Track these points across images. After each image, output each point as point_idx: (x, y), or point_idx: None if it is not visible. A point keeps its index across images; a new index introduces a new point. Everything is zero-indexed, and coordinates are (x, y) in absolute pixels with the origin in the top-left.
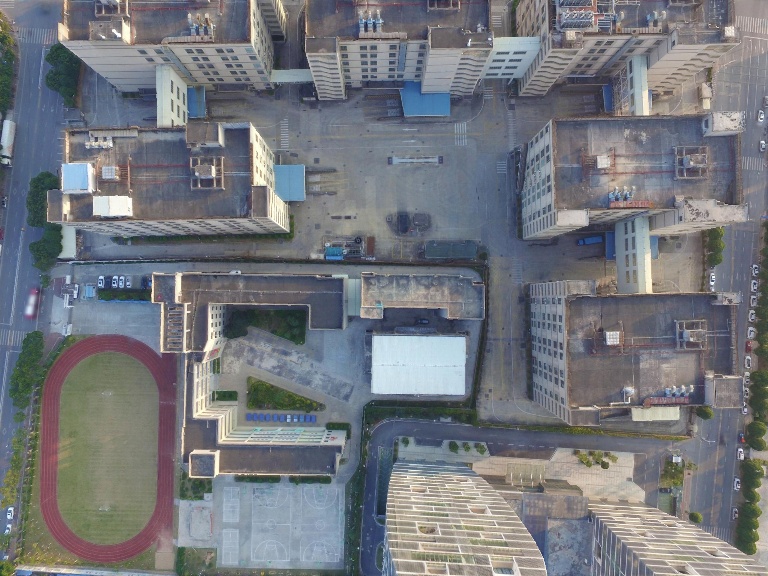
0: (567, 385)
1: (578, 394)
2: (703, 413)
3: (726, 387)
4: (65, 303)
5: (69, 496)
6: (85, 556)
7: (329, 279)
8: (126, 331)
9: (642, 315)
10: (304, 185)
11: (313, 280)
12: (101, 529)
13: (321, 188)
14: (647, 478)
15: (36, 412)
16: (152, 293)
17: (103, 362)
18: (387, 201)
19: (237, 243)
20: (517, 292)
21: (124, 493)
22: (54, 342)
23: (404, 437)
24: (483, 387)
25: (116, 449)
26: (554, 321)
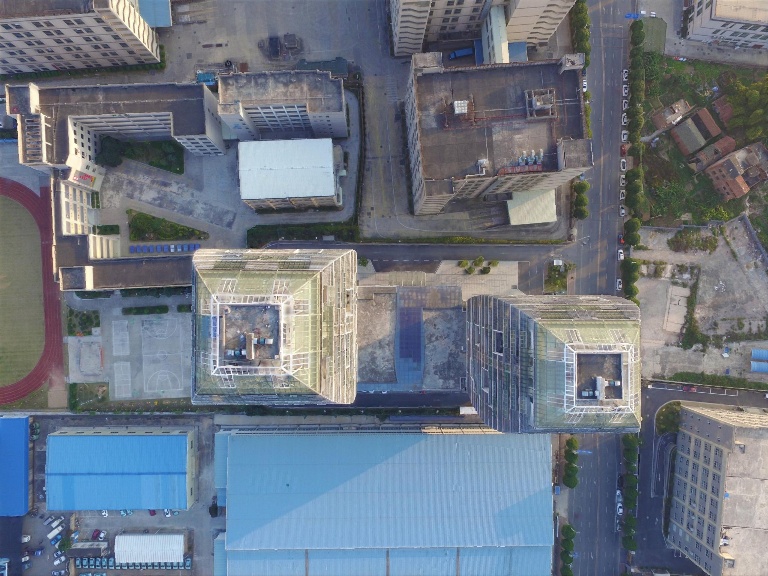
0: (421, 159)
1: (434, 169)
2: (578, 211)
3: (574, 148)
4: None
5: None
6: None
7: (189, 86)
8: (2, 172)
9: (492, 88)
10: (169, 10)
11: (173, 88)
12: None
13: (191, 18)
14: (532, 285)
15: None
16: (7, 105)
17: None
18: (258, 27)
19: (108, 77)
20: (393, 110)
21: (11, 334)
22: None
23: None
24: (365, 205)
25: None
26: None
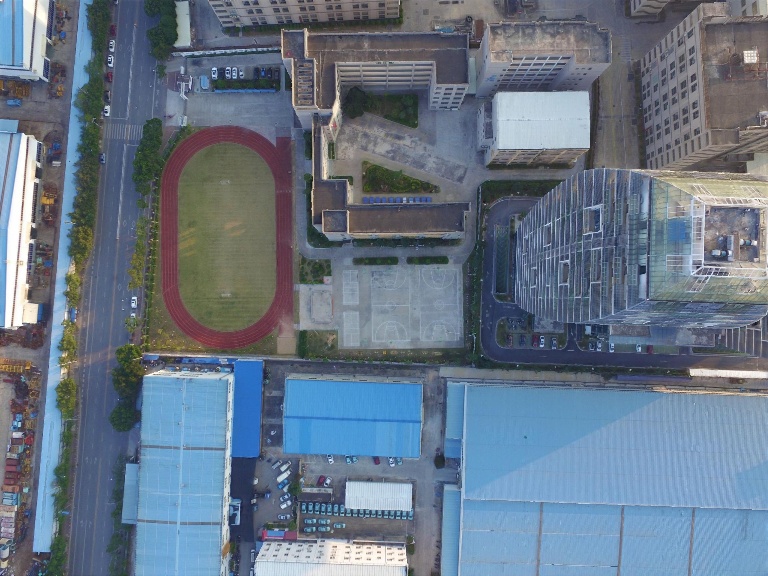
0: (704, 108)
1: (714, 120)
2: None
3: None
4: (182, 91)
5: (190, 285)
6: (208, 343)
7: (453, 36)
8: (240, 122)
9: None
10: None
11: (437, 38)
12: (223, 316)
13: None
14: None
15: (155, 202)
16: (282, 49)
17: (219, 153)
18: None
19: (347, 31)
20: (626, 70)
21: (244, 280)
22: (170, 135)
23: (520, 214)
24: (596, 164)
25: (235, 237)
26: (681, 62)
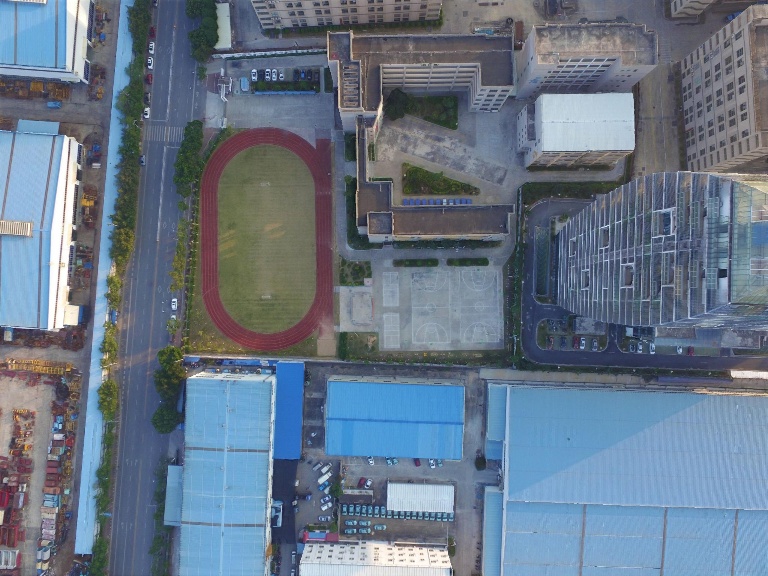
0: (754, 110)
1: (763, 122)
2: None
3: None
4: (222, 93)
5: (230, 287)
6: (248, 345)
7: (498, 38)
8: (280, 124)
9: None
10: None
11: (482, 40)
12: (263, 318)
13: None
14: None
15: (195, 204)
16: (328, 51)
17: (258, 155)
18: None
19: (386, 33)
20: (666, 71)
21: (284, 282)
22: (209, 137)
23: (560, 216)
24: (636, 165)
25: (275, 239)
26: (728, 64)
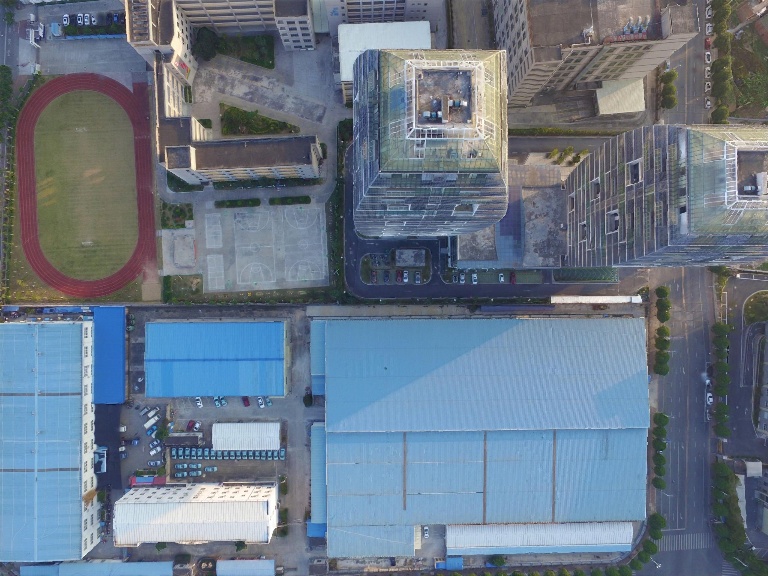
0: (528, 27)
1: (540, 39)
2: (667, 100)
3: (681, 14)
4: (31, 39)
5: (50, 235)
6: (71, 293)
7: None
8: (95, 69)
9: None
10: None
11: None
12: (85, 265)
13: None
14: None
15: (10, 153)
16: None
17: (74, 101)
18: None
19: None
20: (480, 5)
21: (105, 228)
22: (23, 84)
23: None
24: None
25: (94, 185)
26: None
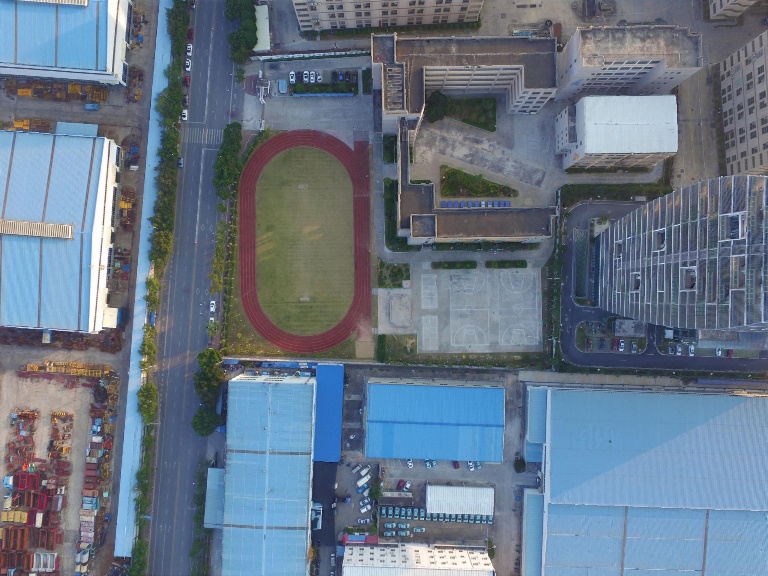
0: None
1: None
2: None
3: None
4: (261, 96)
5: (268, 289)
6: (287, 347)
7: (541, 40)
8: (318, 126)
9: None
10: None
11: (525, 42)
12: (301, 320)
13: None
14: None
15: (234, 207)
16: (372, 53)
17: (296, 157)
18: None
19: (424, 35)
20: (705, 73)
21: (322, 284)
22: (247, 139)
23: (599, 218)
24: (675, 167)
25: (313, 241)
26: None
